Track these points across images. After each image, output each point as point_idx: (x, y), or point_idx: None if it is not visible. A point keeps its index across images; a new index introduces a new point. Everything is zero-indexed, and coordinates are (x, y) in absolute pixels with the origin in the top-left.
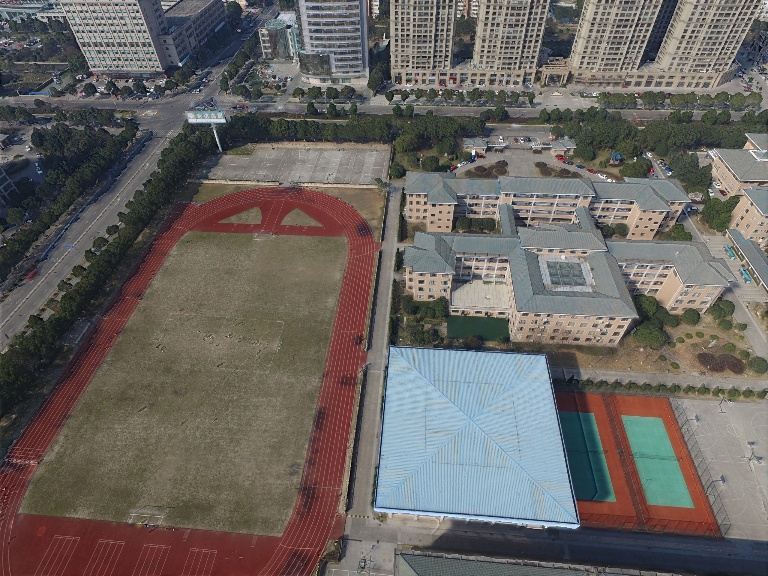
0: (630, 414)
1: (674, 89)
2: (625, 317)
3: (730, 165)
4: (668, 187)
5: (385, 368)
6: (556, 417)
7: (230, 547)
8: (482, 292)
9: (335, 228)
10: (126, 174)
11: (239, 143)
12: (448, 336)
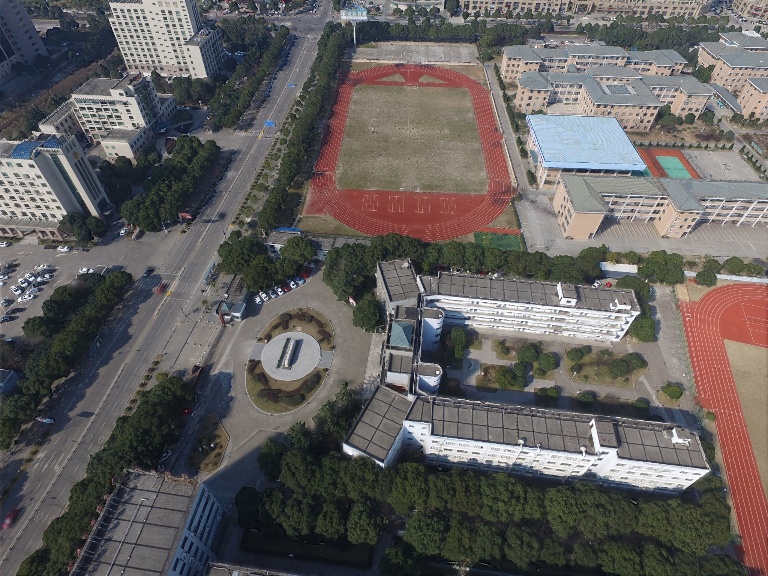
0: (660, 155)
1: (668, 17)
2: (656, 105)
3: (710, 50)
4: (673, 54)
5: (518, 137)
6: (627, 136)
7: (461, 197)
8: (565, 108)
9: (457, 84)
10: (293, 57)
11: (365, 41)
12: None
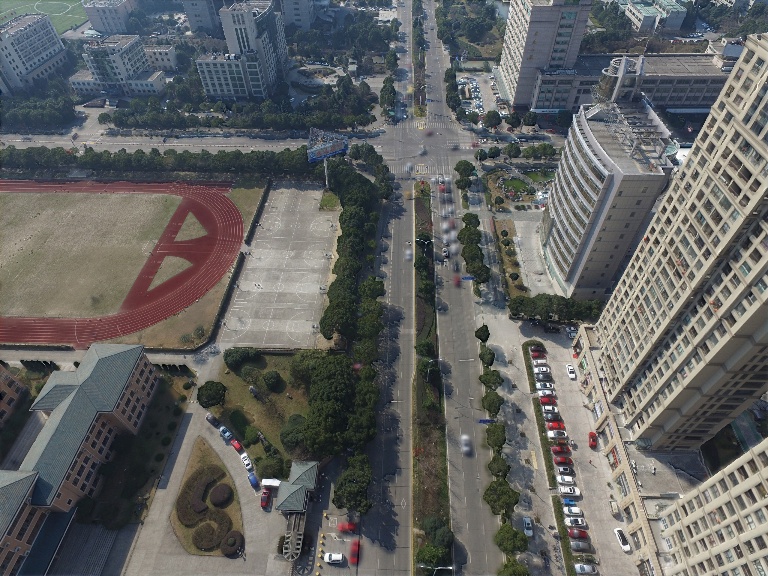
0: None
1: None
2: None
3: None
4: None
5: None
6: None
7: None
8: None
9: (138, 302)
10: (295, 142)
11: None
12: None
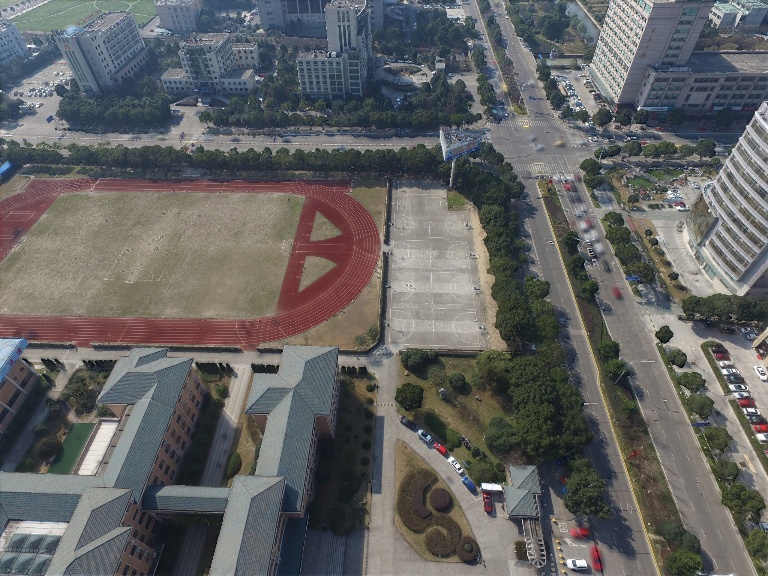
0: None
1: None
2: None
3: None
4: None
5: (55, 359)
6: None
7: None
8: None
9: (293, 303)
10: (401, 140)
11: None
12: (76, 423)
